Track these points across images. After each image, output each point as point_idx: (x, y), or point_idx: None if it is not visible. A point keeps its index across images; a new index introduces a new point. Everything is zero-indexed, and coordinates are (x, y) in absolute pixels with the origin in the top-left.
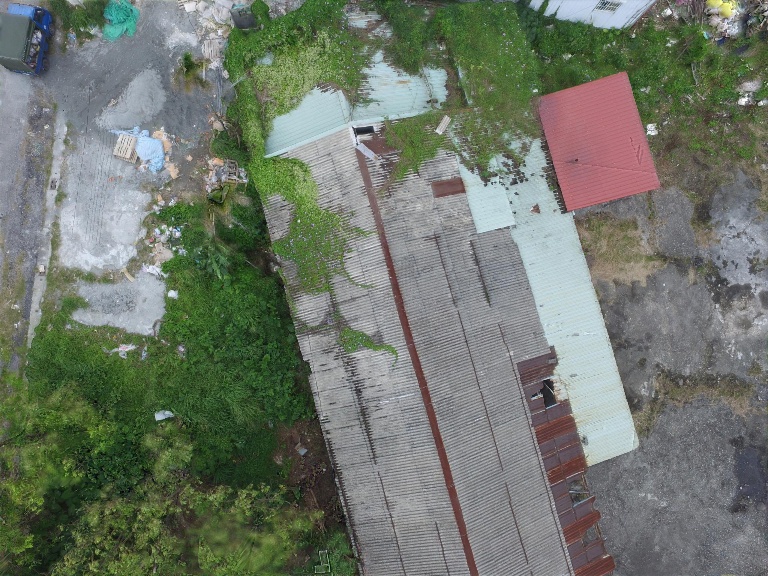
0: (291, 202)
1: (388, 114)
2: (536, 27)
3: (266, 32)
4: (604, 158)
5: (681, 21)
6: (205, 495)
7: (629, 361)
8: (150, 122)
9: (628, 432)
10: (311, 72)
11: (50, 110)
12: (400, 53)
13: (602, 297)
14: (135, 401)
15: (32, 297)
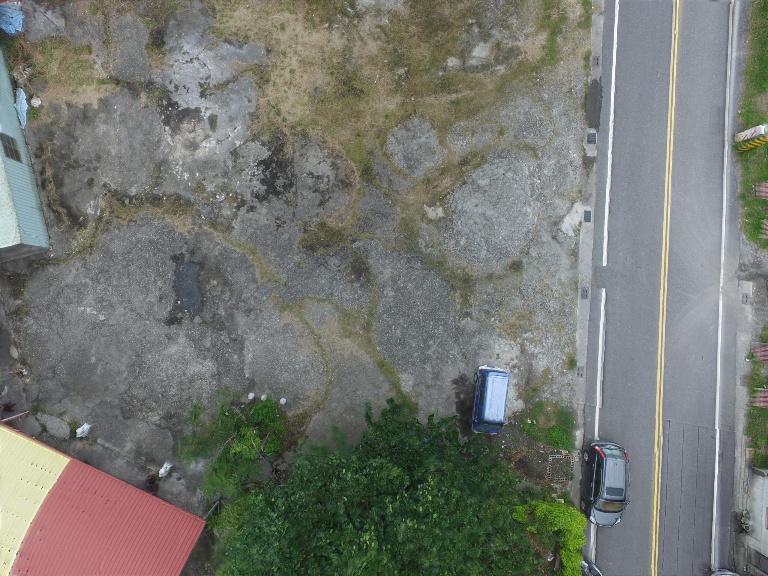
0: None
1: None
2: None
3: None
4: None
5: None
6: None
7: (77, 181)
8: None
9: (7, 227)
10: None
11: None
12: None
13: (53, 118)
14: None
15: None
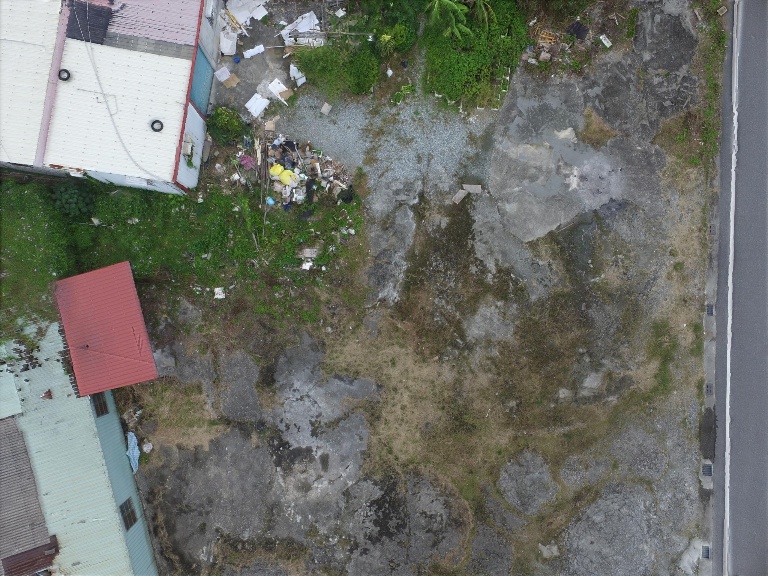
0: None
1: None
2: (75, 203)
3: None
4: (110, 346)
5: None
6: None
7: (189, 526)
8: None
9: None
10: None
11: None
12: None
13: (165, 462)
14: None
15: None
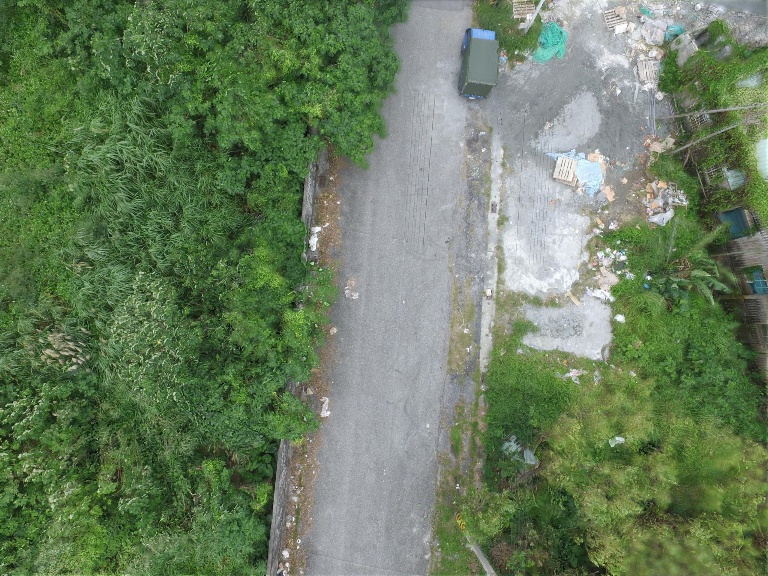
0: None
1: None
2: None
3: None
4: None
5: None
6: (649, 523)
7: None
8: (585, 145)
9: None
10: None
11: (486, 133)
12: None
13: None
14: (595, 427)
15: (481, 321)
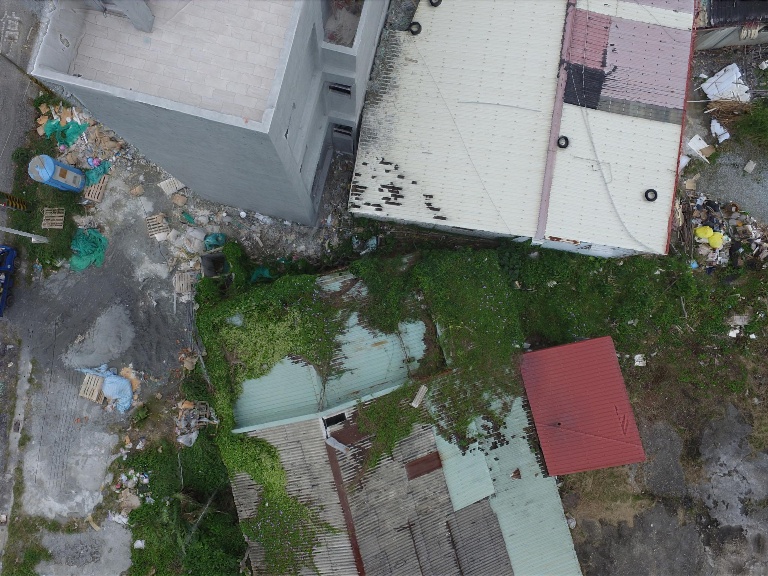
0: (259, 483)
1: (362, 382)
2: (519, 269)
3: (234, 303)
4: (588, 425)
5: (670, 248)
6: None
7: None
8: (118, 358)
9: None
10: (281, 344)
11: (14, 347)
12: (375, 317)
13: (587, 538)
14: None
15: None
